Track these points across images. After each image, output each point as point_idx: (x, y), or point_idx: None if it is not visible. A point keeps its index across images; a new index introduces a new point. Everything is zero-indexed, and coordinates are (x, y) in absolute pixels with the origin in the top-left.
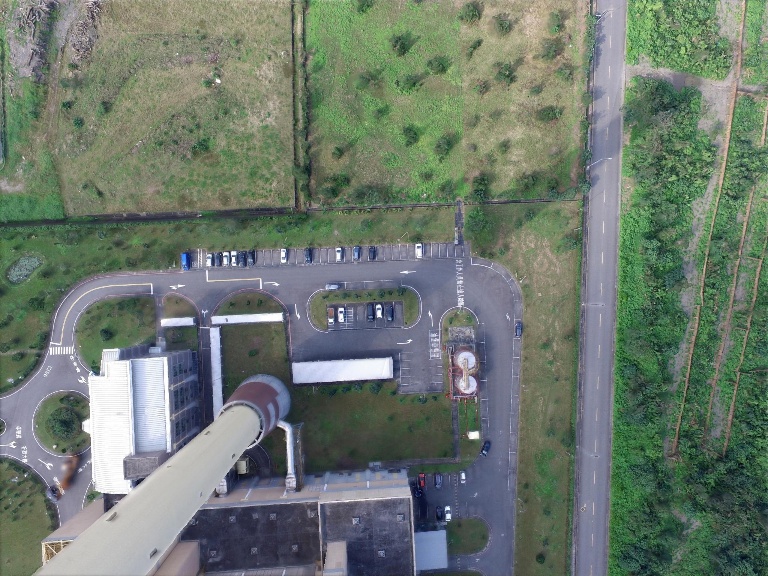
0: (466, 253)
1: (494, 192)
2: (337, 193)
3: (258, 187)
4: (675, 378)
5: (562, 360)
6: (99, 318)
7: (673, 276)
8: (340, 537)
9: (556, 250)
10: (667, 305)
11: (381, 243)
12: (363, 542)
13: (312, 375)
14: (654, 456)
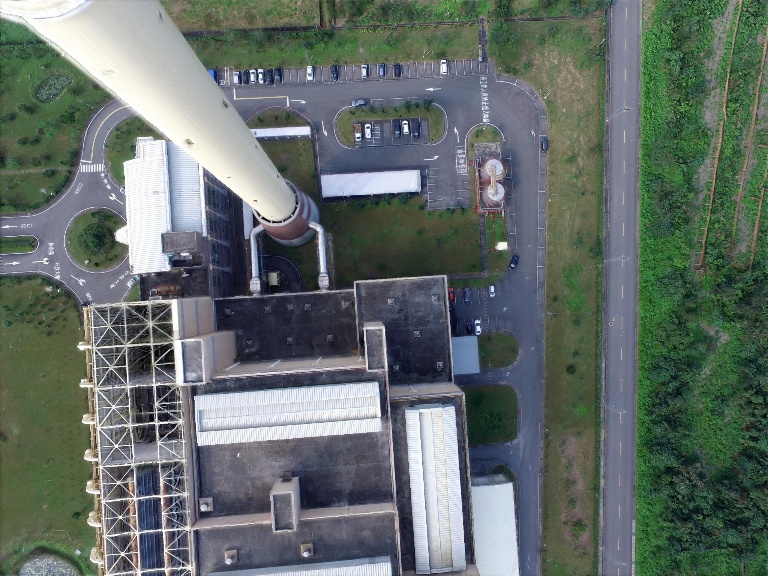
0: (490, 70)
1: (517, 10)
2: (361, 11)
3: (283, 6)
4: (700, 193)
5: (588, 175)
6: (129, 132)
7: (696, 89)
8: (376, 318)
9: (580, 64)
10: (690, 120)
11: (406, 60)
12: (399, 323)
13: (341, 188)
14: (682, 265)
